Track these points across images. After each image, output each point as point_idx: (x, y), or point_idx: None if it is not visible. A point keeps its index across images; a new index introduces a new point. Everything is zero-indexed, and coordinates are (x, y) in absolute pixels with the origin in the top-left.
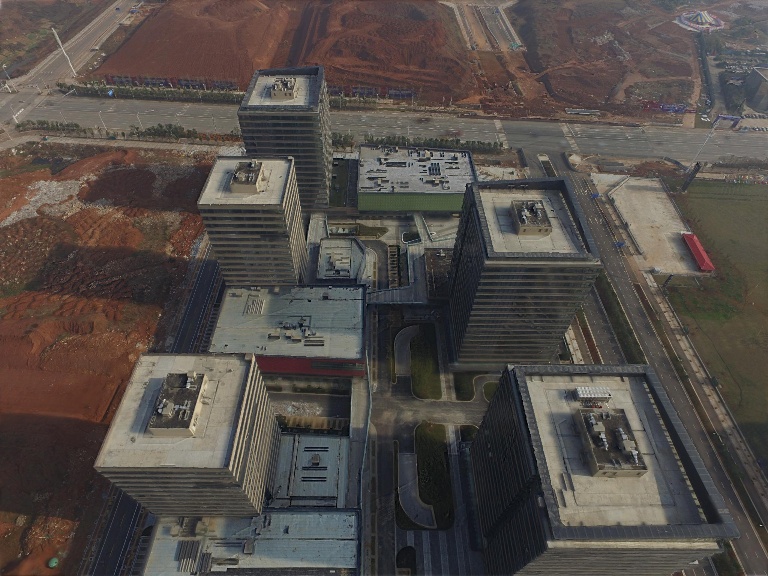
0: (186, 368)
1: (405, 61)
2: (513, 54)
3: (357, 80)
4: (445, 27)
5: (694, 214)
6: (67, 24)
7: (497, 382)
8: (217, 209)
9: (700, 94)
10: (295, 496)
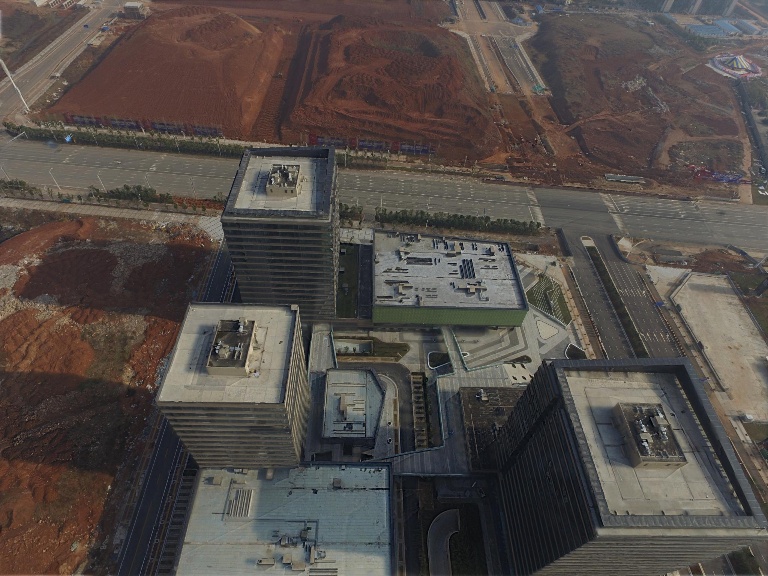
0: None
1: (419, 107)
2: (537, 99)
3: (364, 129)
4: (461, 65)
5: None
6: (26, 41)
7: None
8: (186, 406)
9: (752, 159)
10: None
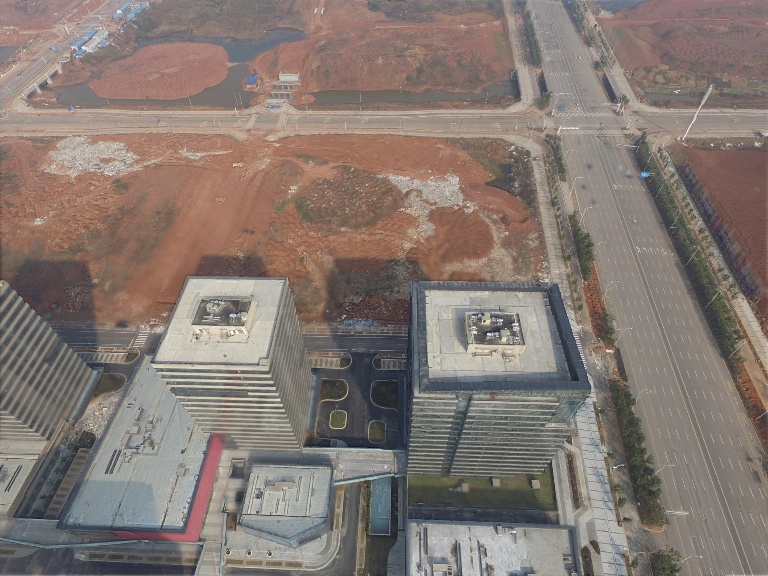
0: None
1: None
2: None
3: None
4: None
5: None
6: None
7: None
8: None
9: None
10: None
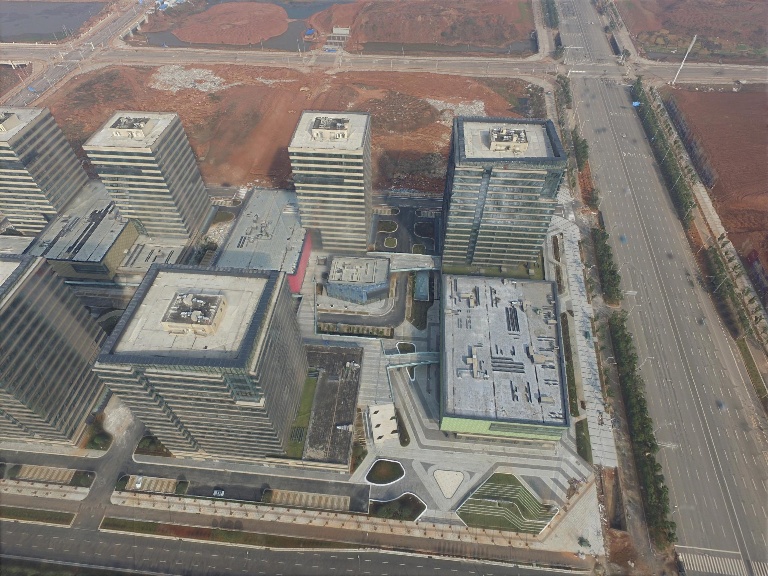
0: (159, 129)
1: None
2: None
3: None
4: None
5: None
6: None
7: None
8: None
9: None
10: (144, 246)
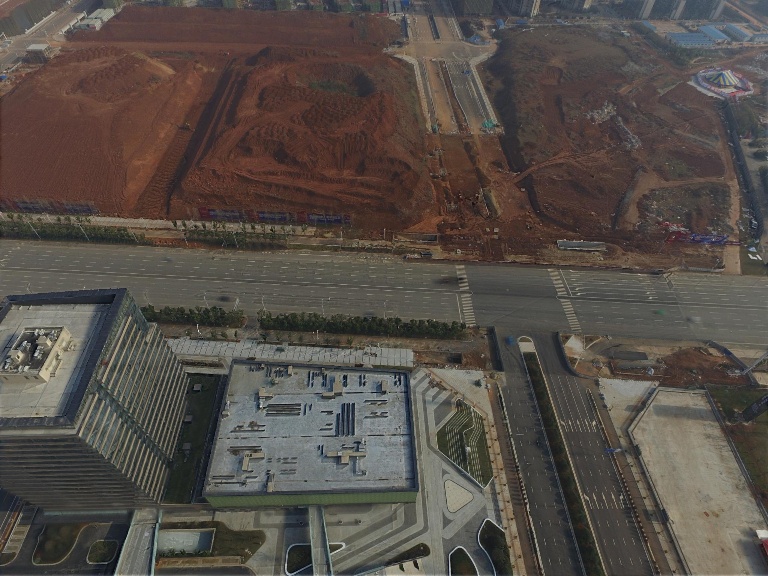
0: None
1: (337, 163)
2: (486, 139)
3: (268, 195)
4: (397, 102)
5: None
6: None
7: None
8: None
9: (740, 208)
10: None
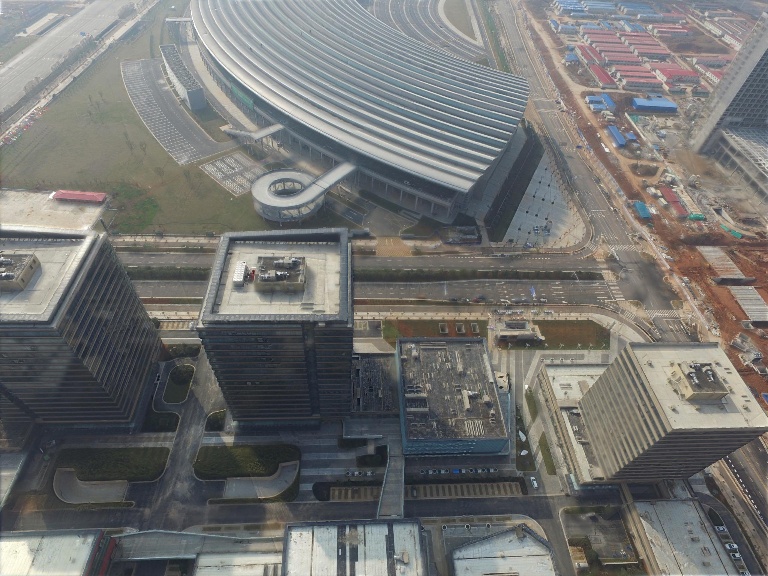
0: None
1: None
2: None
3: None
4: None
5: (33, 181)
6: None
7: (165, 389)
8: None
9: None
10: None
